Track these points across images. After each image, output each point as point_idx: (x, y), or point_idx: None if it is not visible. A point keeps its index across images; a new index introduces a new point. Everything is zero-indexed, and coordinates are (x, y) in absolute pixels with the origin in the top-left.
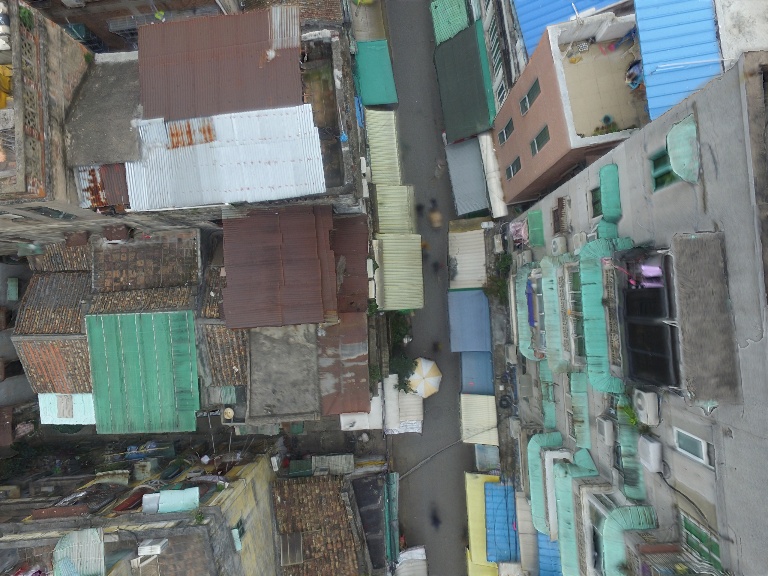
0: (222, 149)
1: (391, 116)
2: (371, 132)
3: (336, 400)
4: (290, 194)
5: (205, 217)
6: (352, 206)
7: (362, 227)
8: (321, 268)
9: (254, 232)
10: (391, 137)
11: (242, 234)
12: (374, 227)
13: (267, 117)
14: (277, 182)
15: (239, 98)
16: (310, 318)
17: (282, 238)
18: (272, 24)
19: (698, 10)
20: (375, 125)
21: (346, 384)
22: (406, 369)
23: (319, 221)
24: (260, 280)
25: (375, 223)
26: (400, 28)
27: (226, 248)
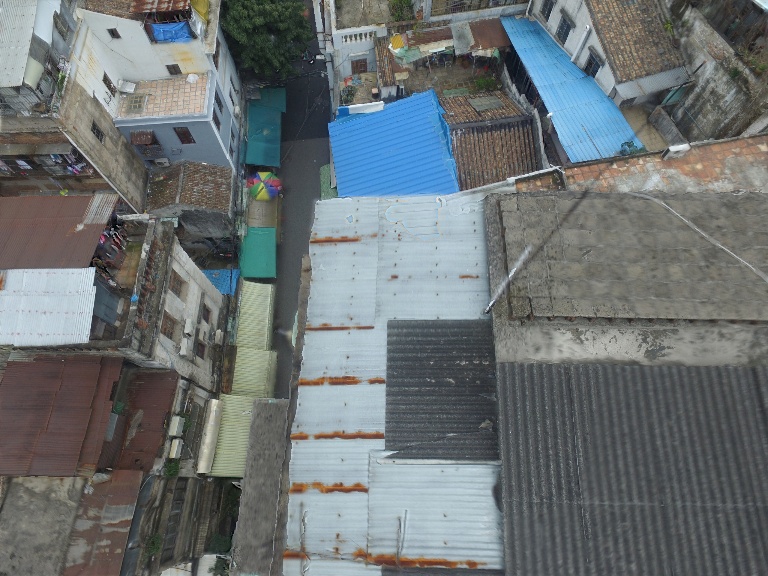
0: (7, 297)
1: (268, 288)
2: (245, 300)
3: (80, 573)
4: (55, 342)
5: (5, 359)
6: (146, 360)
7: (169, 383)
8: (91, 418)
9: (35, 376)
10: (265, 306)
11: (22, 377)
12: (219, 387)
13: (55, 275)
14: (47, 330)
15: (38, 257)
16: (60, 470)
17: (60, 384)
18: (91, 205)
19: (432, 226)
20: (251, 294)
21: (98, 554)
22: (227, 549)
23: (106, 372)
24: (22, 425)
25: (227, 384)
26: (298, 220)
27: (0, 389)
